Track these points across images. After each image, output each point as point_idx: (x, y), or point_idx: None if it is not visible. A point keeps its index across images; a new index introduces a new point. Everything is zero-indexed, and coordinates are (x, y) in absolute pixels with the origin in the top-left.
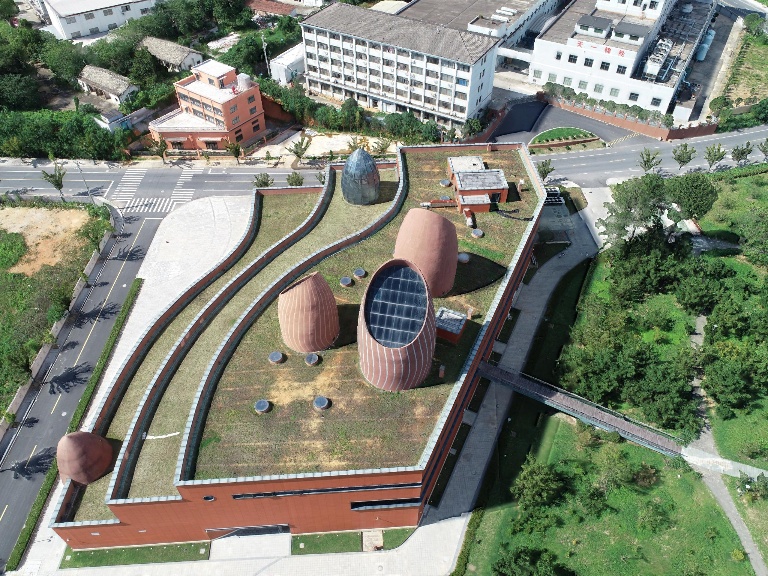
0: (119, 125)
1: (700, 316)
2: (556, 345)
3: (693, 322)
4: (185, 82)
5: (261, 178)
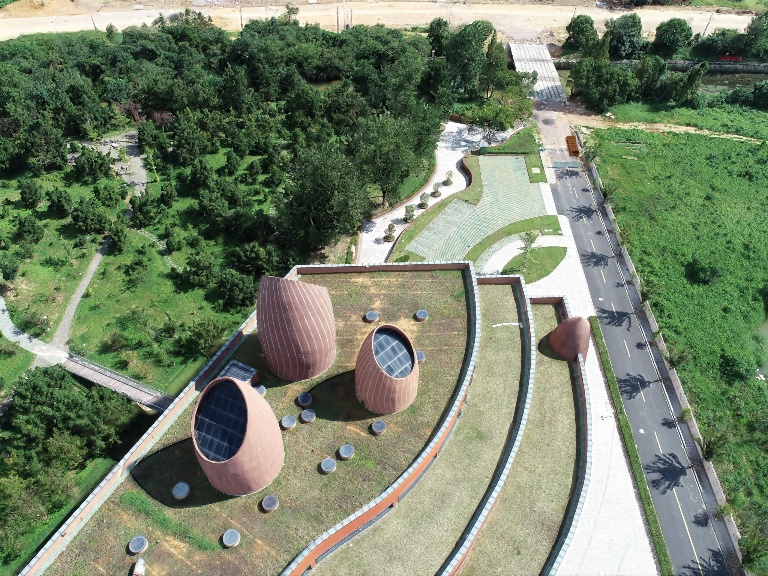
0: None
1: None
2: None
3: None
4: None
5: None
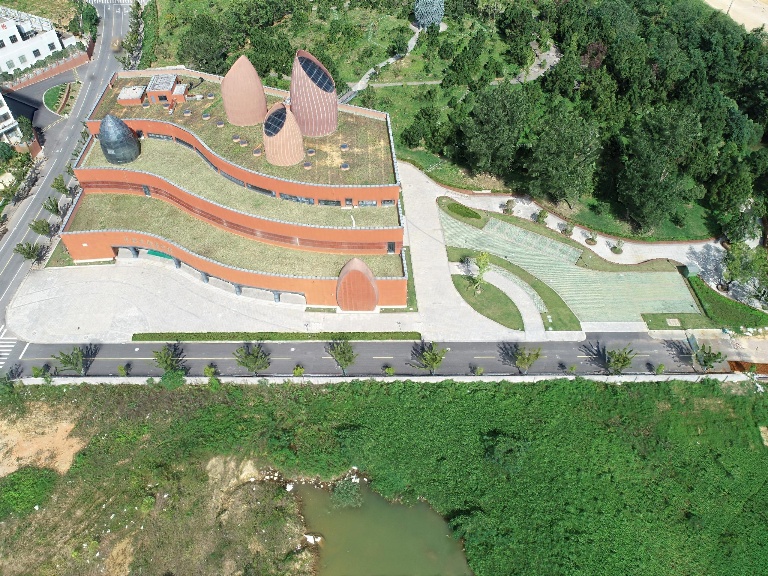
0: None
1: (269, 74)
2: None
3: (273, 77)
4: None
5: (19, 251)
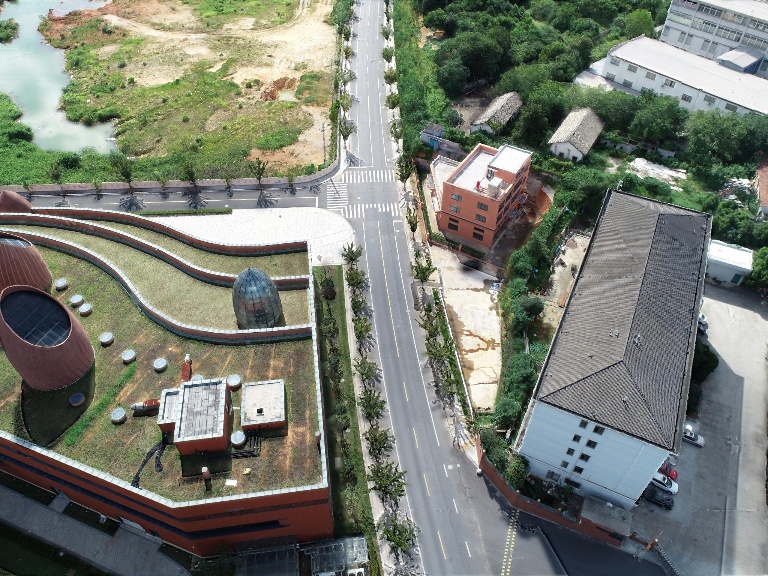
0: (429, 139)
1: None
2: (35, 573)
3: None
4: (491, 151)
5: None
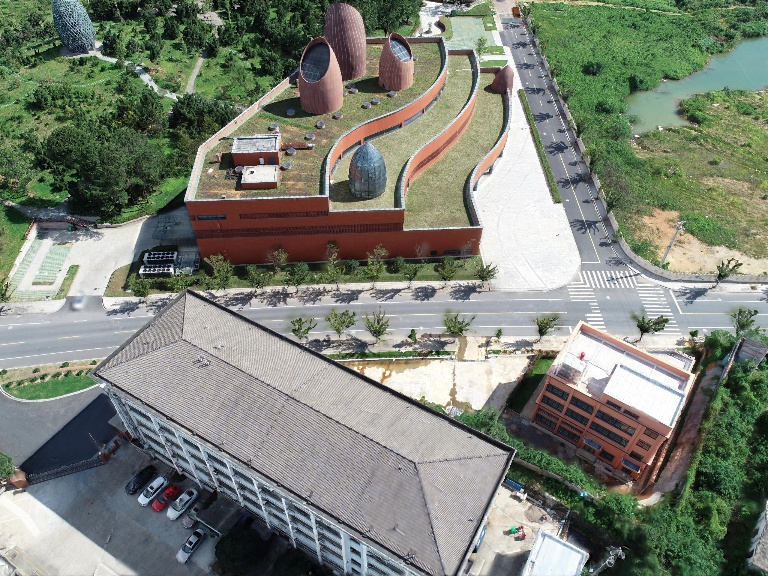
0: None
1: None
2: None
3: None
4: None
5: None
